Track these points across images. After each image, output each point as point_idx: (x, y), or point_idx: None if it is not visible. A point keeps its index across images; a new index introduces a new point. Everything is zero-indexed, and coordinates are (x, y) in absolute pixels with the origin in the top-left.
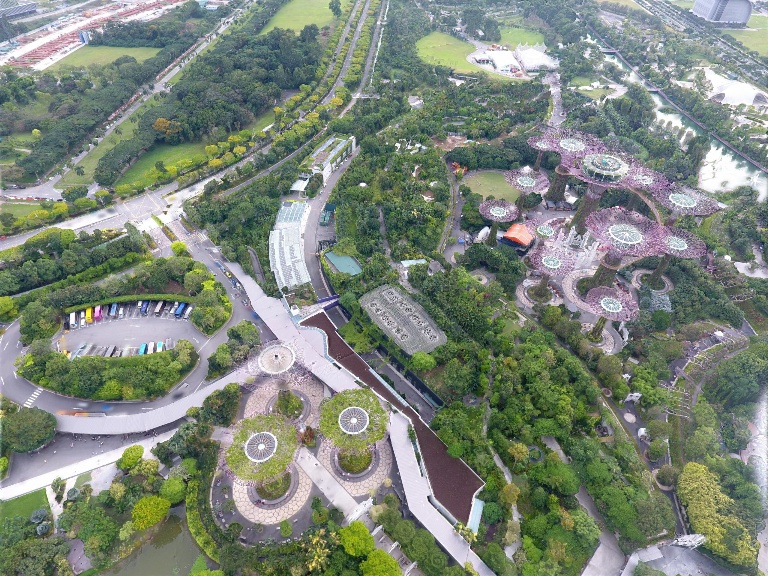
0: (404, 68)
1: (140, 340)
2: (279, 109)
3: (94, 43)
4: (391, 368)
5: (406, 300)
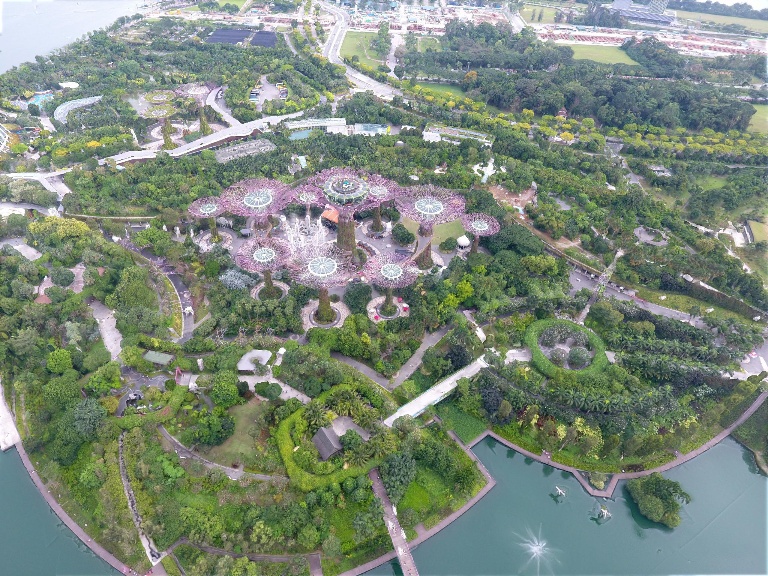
0: None
1: None
2: (528, 111)
3: (623, 47)
4: None
5: None
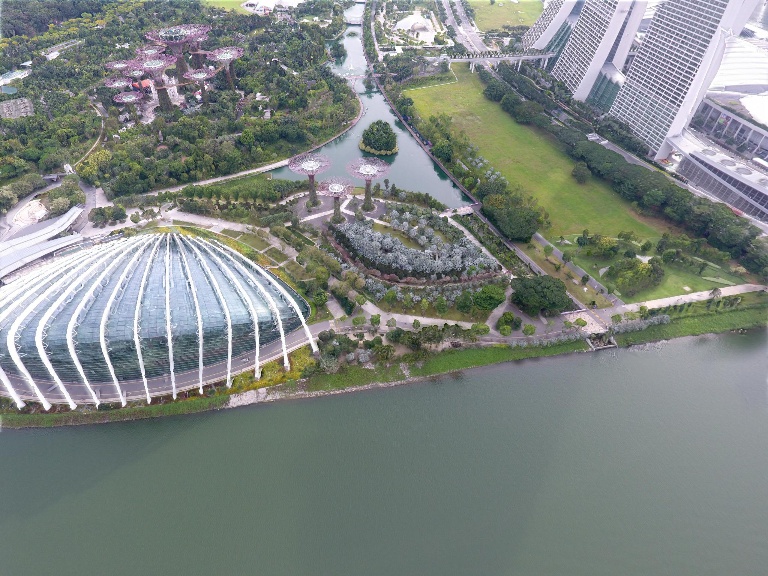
0: (181, 7)
1: None
2: (52, 25)
3: None
4: (4, 134)
5: (28, 103)
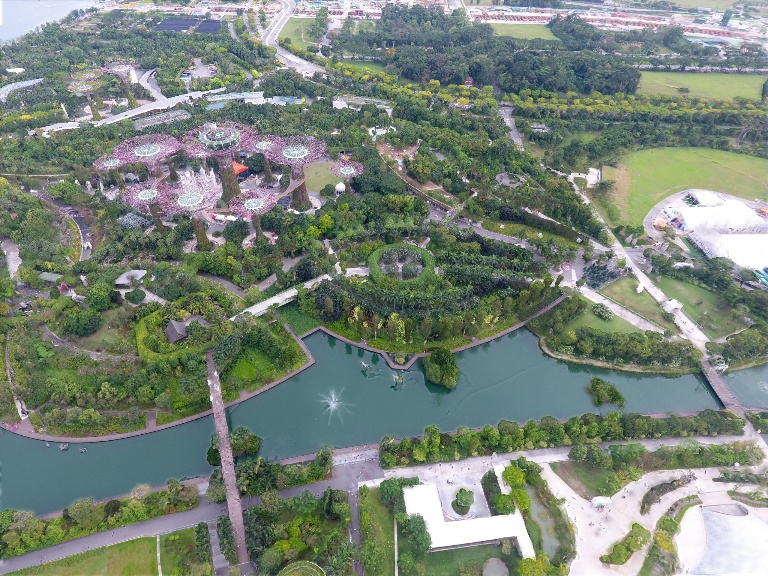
0: None
1: None
2: (434, 81)
3: (549, 25)
4: None
5: None
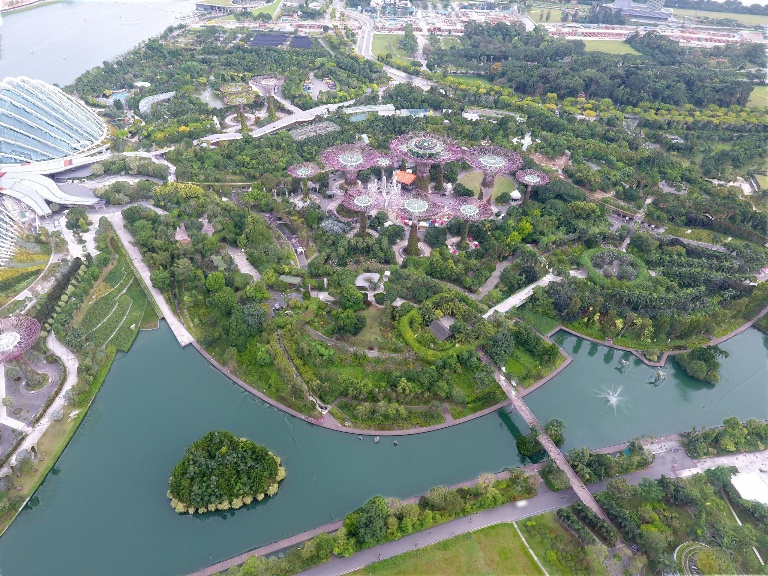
0: None
1: (315, 92)
2: (552, 95)
3: (627, 41)
4: None
5: None
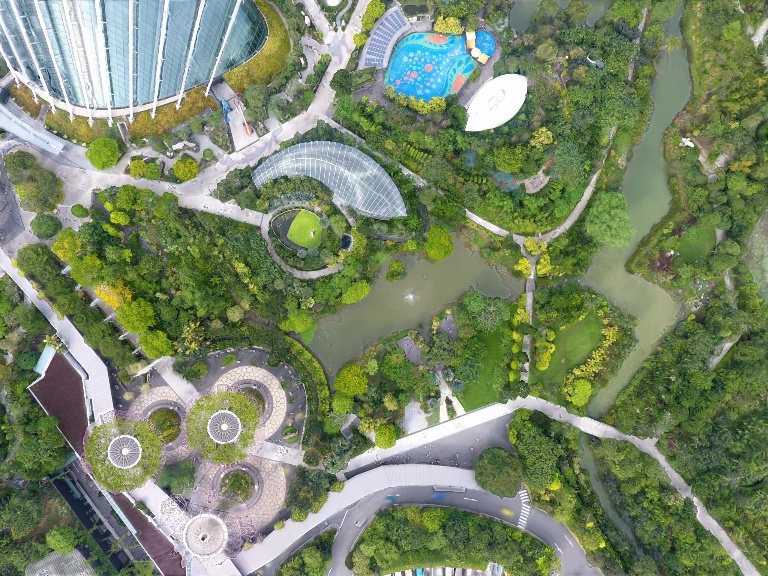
0: None
1: None
2: None
3: None
4: (118, 537)
5: None
